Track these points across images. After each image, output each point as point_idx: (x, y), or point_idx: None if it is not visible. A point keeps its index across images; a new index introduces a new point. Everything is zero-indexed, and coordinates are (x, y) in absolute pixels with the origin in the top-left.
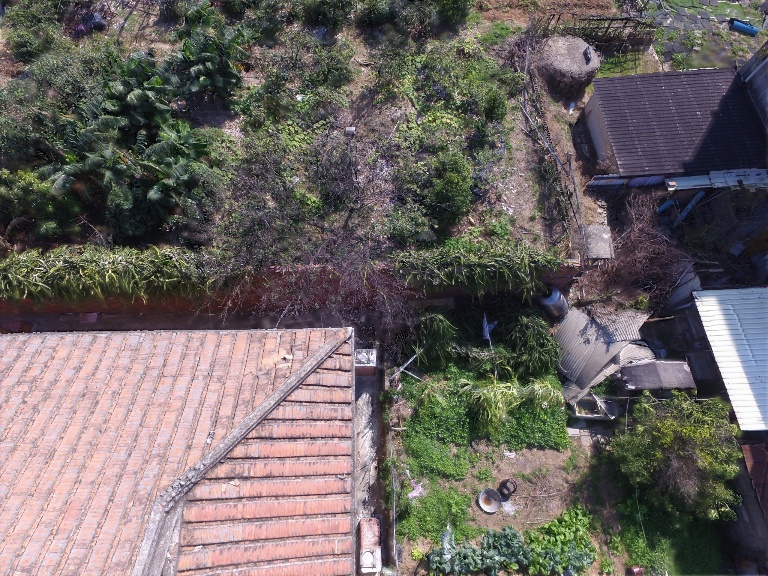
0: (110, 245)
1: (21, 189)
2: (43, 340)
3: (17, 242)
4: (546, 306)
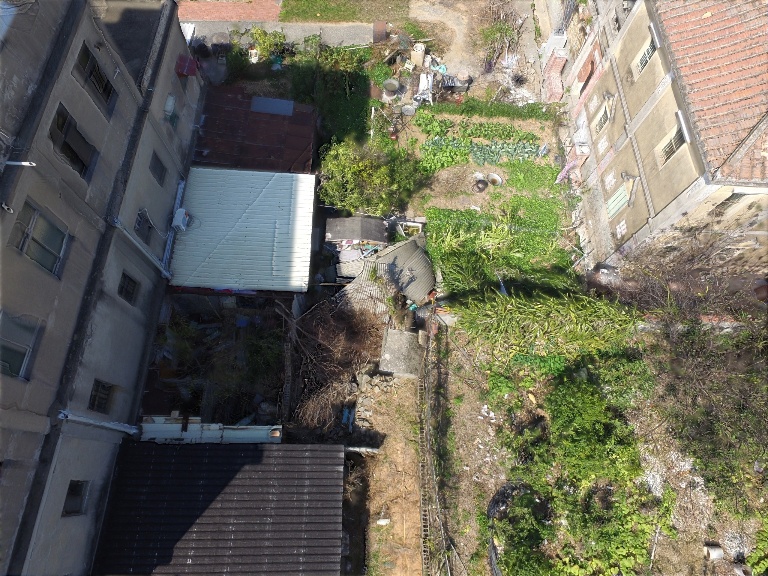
0: None
1: None
2: None
3: None
4: None
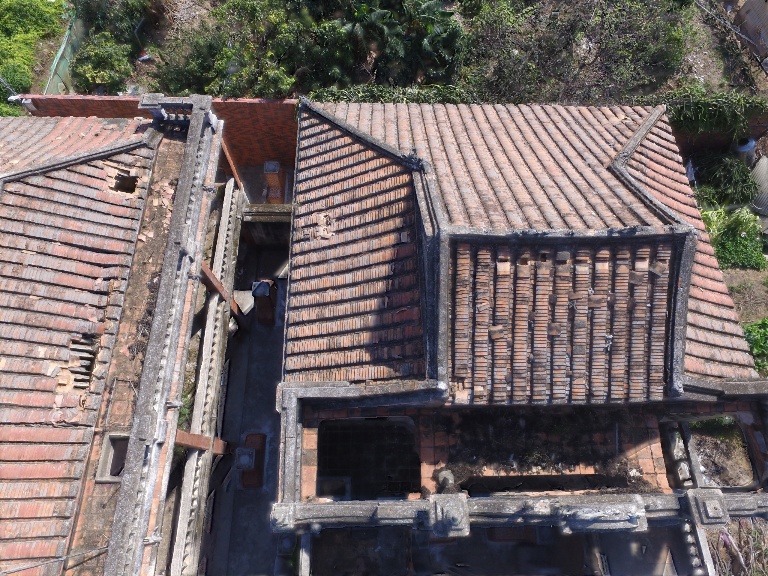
0: (393, 84)
1: (313, 39)
2: (429, 106)
3: (295, 91)
4: (741, 154)
